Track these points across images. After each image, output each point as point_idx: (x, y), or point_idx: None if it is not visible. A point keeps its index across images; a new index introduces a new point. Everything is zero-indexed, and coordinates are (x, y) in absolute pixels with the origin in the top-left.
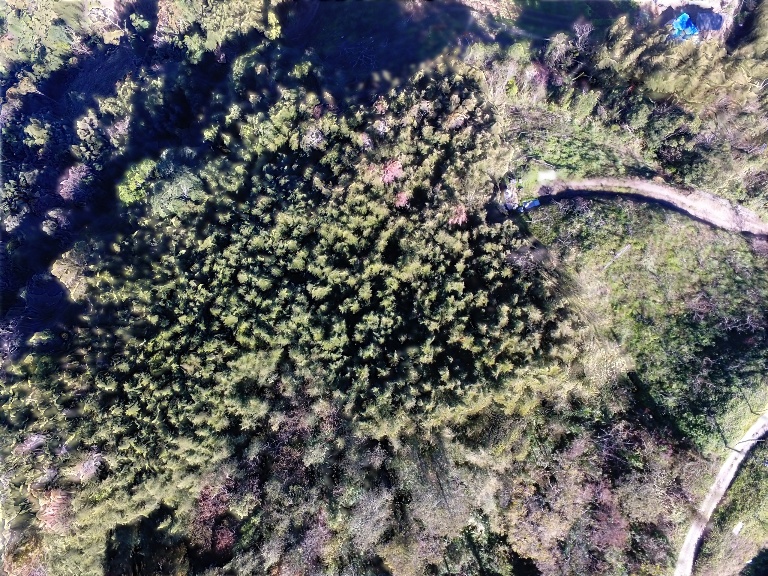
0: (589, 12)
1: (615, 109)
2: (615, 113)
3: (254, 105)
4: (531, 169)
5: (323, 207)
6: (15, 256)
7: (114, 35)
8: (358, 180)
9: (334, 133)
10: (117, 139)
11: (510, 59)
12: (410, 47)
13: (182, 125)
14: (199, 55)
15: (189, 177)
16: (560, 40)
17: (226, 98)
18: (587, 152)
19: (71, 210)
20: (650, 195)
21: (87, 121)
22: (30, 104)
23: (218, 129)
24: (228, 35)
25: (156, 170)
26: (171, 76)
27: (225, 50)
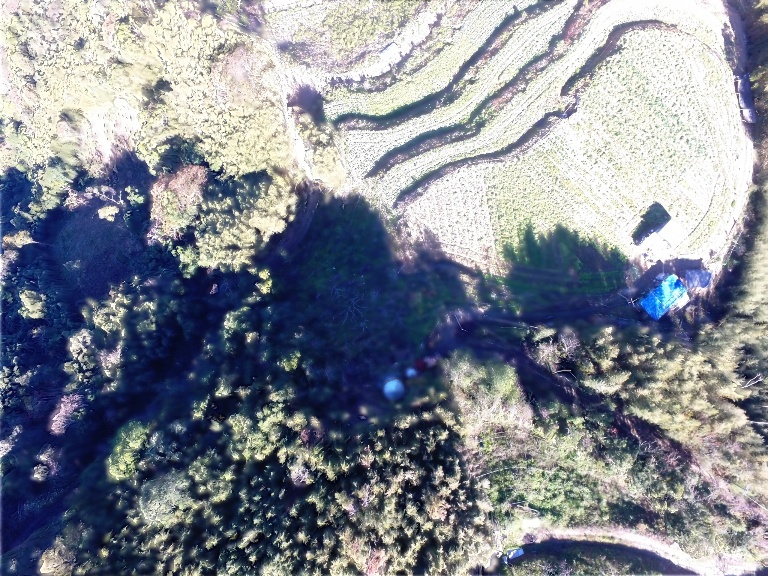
0: (579, 265)
1: (600, 434)
2: (600, 437)
3: (243, 398)
4: (515, 519)
5: (308, 572)
6: (7, 486)
7: (109, 212)
8: (342, 554)
9: (320, 470)
10: (109, 369)
11: (496, 390)
12: (400, 311)
13: (174, 345)
14: (192, 269)
15: (177, 487)
16: (548, 333)
17: (217, 348)
18: (572, 489)
19: (63, 449)
20: (633, 545)
21: (80, 340)
22: (26, 251)
23: (208, 402)
24: (220, 267)
25: (146, 442)
26: (164, 300)
27: (218, 271)
